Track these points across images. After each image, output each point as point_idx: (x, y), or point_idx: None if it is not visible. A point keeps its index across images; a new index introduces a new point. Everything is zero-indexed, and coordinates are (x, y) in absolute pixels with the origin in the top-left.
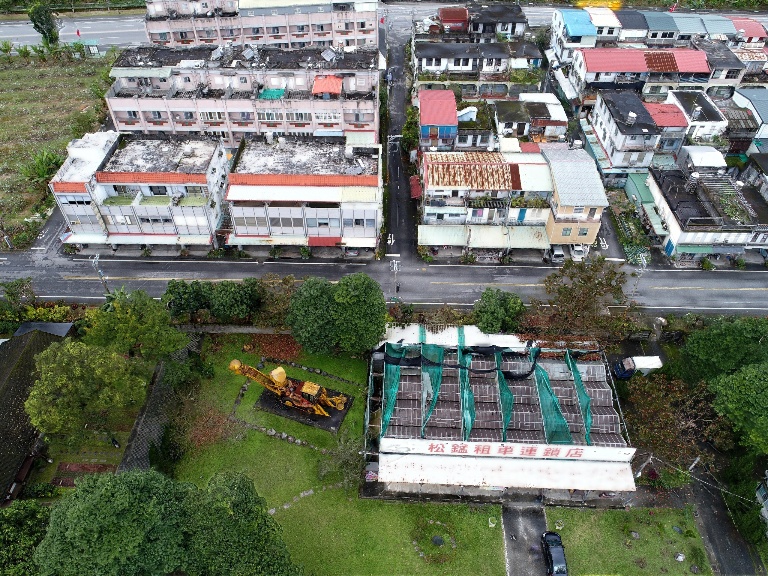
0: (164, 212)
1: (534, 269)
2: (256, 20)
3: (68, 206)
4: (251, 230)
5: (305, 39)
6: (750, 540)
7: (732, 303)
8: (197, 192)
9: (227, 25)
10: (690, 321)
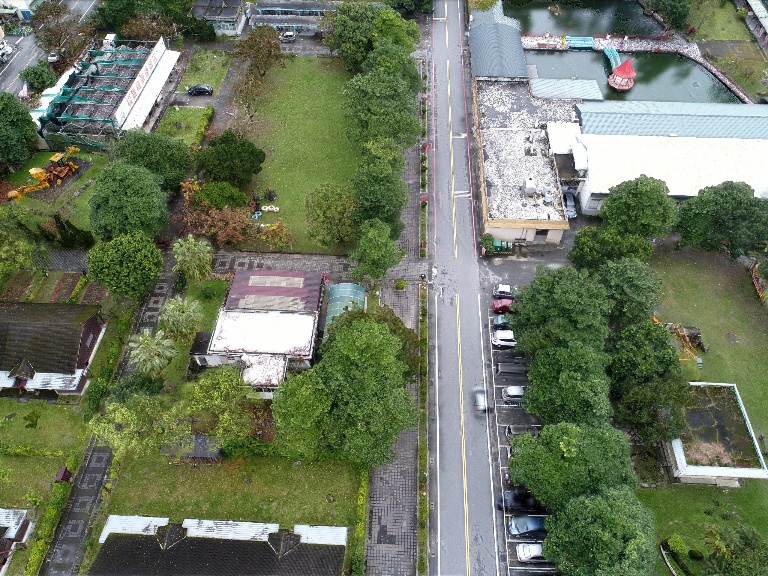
0: None
1: (5, 72)
2: None
3: None
4: None
5: None
6: (214, 36)
7: (84, 9)
8: None
9: None
10: (89, 21)
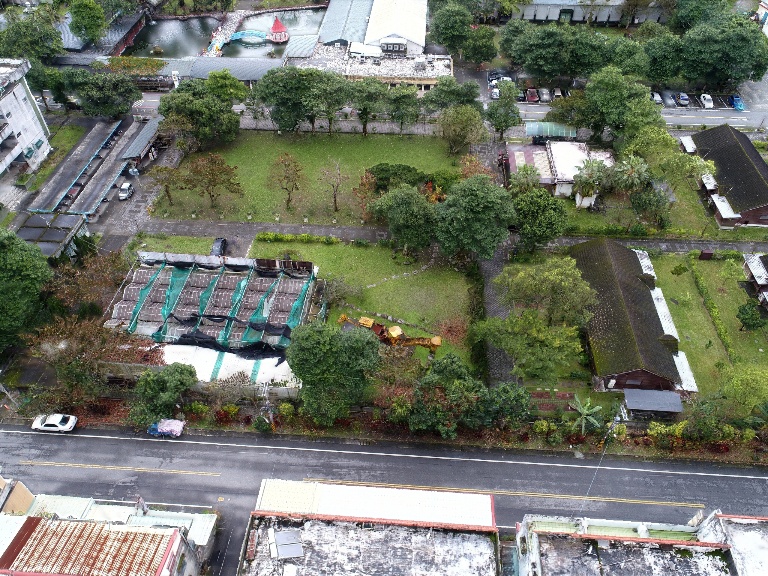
0: None
1: (75, 494)
2: None
3: None
4: None
5: None
6: None
7: None
8: None
9: None
10: None
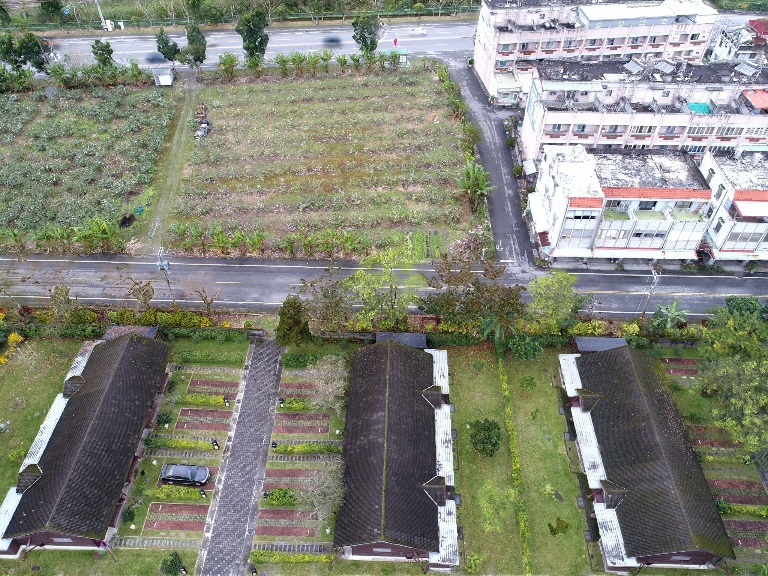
0: (664, 227)
1: None
2: (601, 32)
3: (571, 220)
4: (739, 245)
5: (638, 50)
6: None
7: None
8: (683, 207)
9: (572, 36)
10: None
